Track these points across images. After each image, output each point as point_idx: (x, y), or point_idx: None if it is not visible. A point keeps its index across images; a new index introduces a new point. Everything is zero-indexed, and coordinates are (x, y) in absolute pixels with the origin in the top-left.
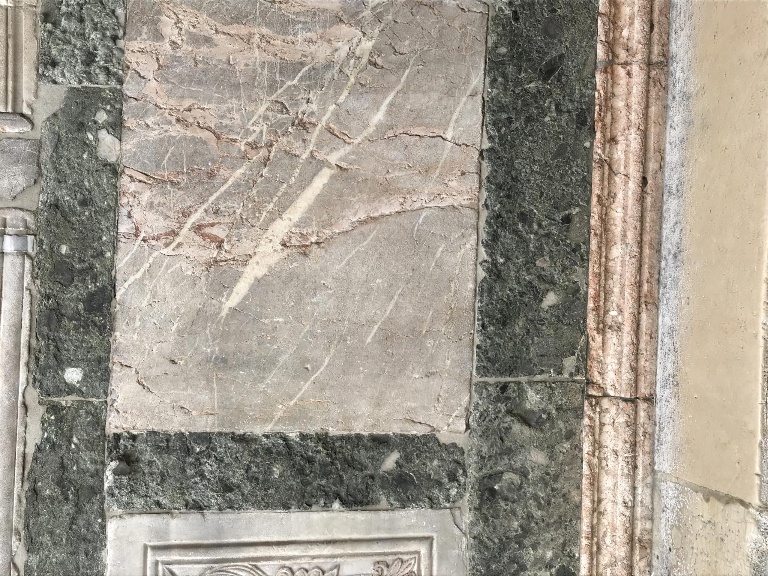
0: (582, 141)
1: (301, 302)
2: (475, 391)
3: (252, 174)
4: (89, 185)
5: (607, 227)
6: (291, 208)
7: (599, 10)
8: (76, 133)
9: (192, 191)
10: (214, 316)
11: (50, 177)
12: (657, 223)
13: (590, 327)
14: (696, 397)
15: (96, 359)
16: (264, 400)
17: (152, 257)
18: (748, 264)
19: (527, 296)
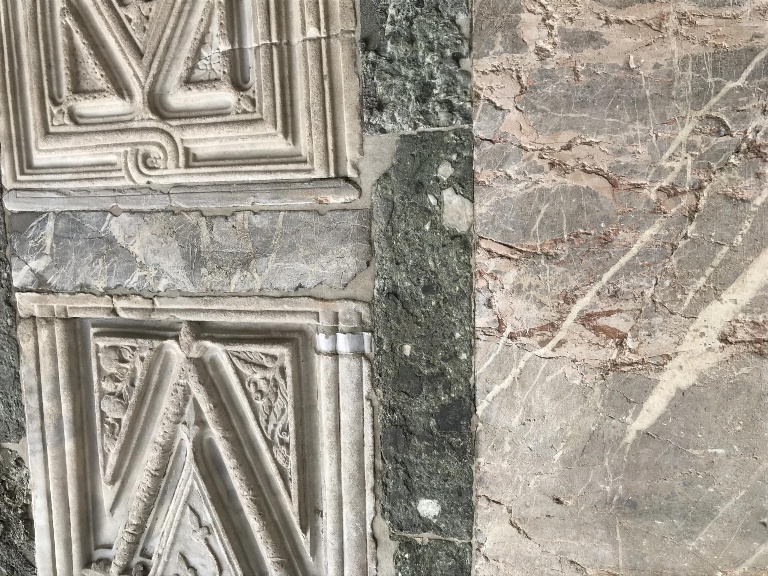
0: None
1: (753, 425)
2: None
3: (670, 235)
4: (435, 265)
5: None
6: (736, 284)
7: None
8: (415, 197)
9: (577, 266)
10: (615, 442)
11: (386, 258)
12: None
13: None
14: None
15: (455, 490)
16: (693, 563)
17: (523, 360)
18: None
19: None
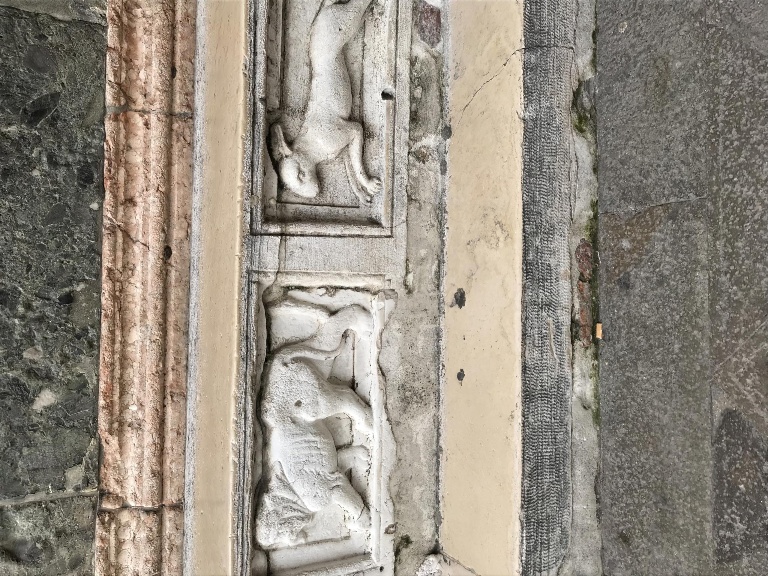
0: (87, 202)
1: None
2: None
3: None
4: None
5: (124, 305)
6: None
7: (107, 43)
8: None
9: None
10: None
11: None
12: (184, 300)
13: (101, 428)
14: (202, 513)
15: None
16: None
17: None
18: (225, 371)
19: (11, 397)
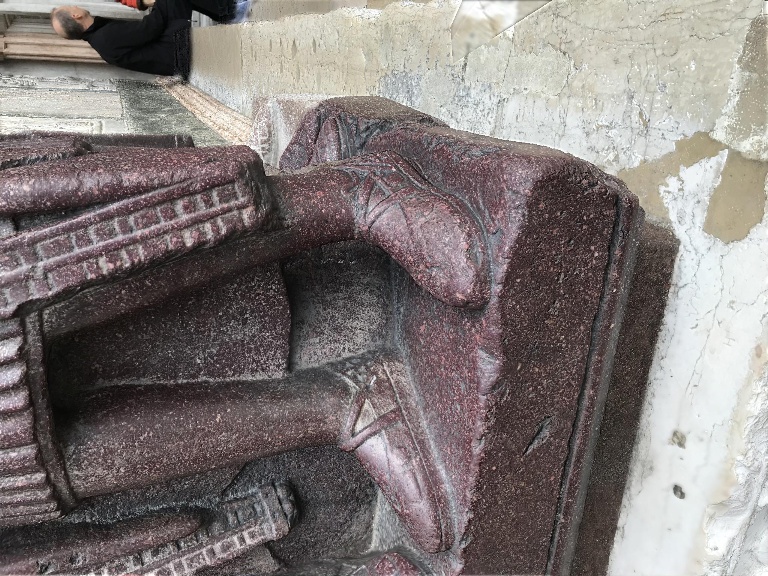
0: None
1: None
2: (126, 114)
3: None
4: None
5: None
6: None
7: None
8: None
9: None
10: None
11: None
12: None
13: None
14: None
15: None
16: None
17: None
18: None
19: None
